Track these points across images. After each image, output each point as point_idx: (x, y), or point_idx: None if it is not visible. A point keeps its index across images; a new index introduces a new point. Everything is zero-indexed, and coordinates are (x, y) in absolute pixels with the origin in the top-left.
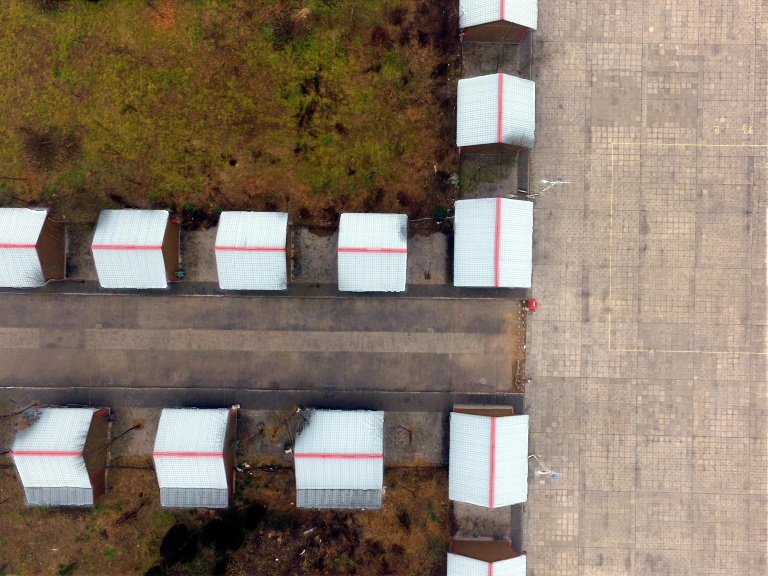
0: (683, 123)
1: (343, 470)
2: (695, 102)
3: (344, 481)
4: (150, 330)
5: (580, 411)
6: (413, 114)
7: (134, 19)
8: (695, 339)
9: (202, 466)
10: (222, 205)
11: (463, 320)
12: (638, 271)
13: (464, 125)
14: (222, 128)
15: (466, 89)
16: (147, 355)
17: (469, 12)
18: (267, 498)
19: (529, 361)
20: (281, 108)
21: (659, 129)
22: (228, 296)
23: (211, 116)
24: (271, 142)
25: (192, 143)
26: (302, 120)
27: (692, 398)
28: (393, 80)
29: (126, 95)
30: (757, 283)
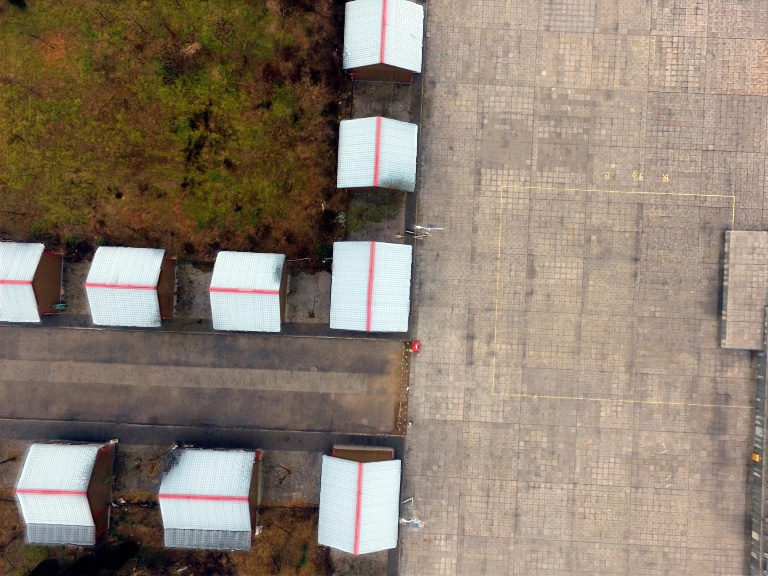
0: (573, 168)
1: (210, 511)
2: (586, 147)
3: (212, 522)
4: (31, 361)
5: (461, 455)
6: (303, 151)
7: (25, 49)
8: (579, 386)
9: (67, 504)
10: (106, 238)
11: (347, 360)
12: (524, 315)
13: (344, 166)
14: (109, 160)
15: (347, 130)
16: (27, 386)
17: (352, 53)
18: (142, 534)
19: (412, 403)
20: (169, 142)
21: (549, 173)
22: (110, 329)
23: (99, 148)
24: (158, 176)
25: (79, 174)
26: (190, 154)
27: (574, 445)
28: (283, 117)
29: (14, 125)
30: (643, 331)
